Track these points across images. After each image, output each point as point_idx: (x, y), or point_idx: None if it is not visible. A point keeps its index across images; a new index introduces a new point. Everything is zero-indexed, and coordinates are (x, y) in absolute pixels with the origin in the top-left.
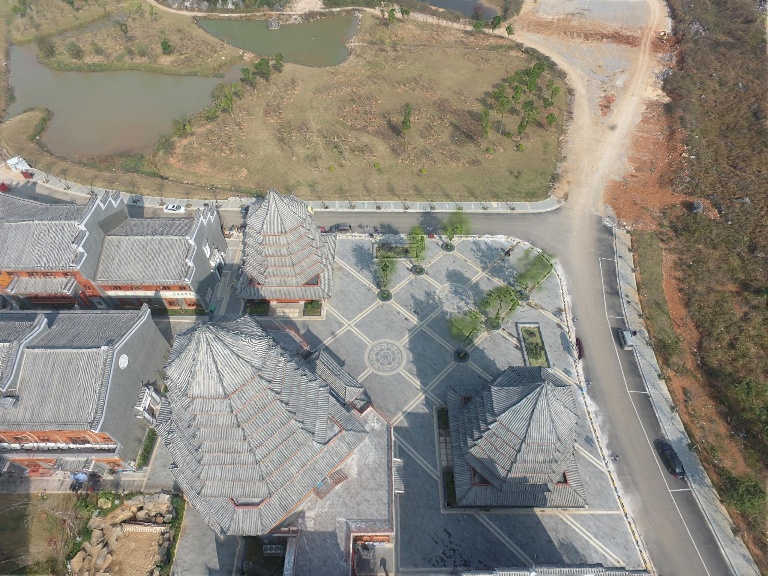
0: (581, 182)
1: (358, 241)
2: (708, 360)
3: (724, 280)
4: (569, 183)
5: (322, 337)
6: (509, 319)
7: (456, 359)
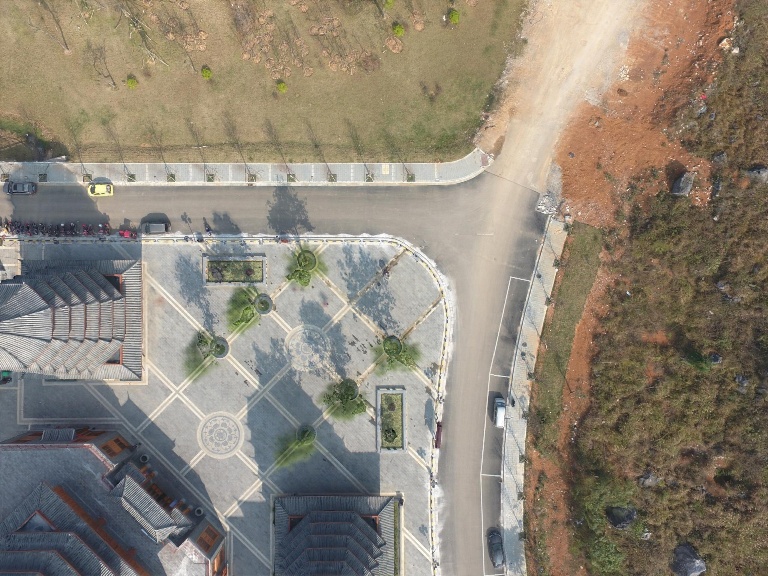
0: (532, 111)
1: (182, 249)
2: (582, 442)
3: (656, 324)
4: (512, 113)
5: (146, 410)
6: (370, 381)
7: (299, 439)
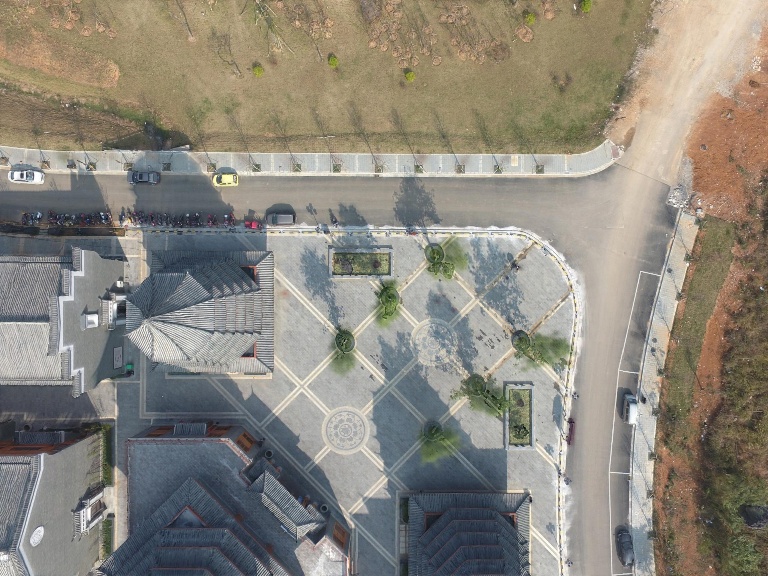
0: (663, 102)
1: (307, 241)
2: (714, 440)
3: None
4: (643, 105)
5: (270, 404)
6: (497, 377)
7: (426, 435)
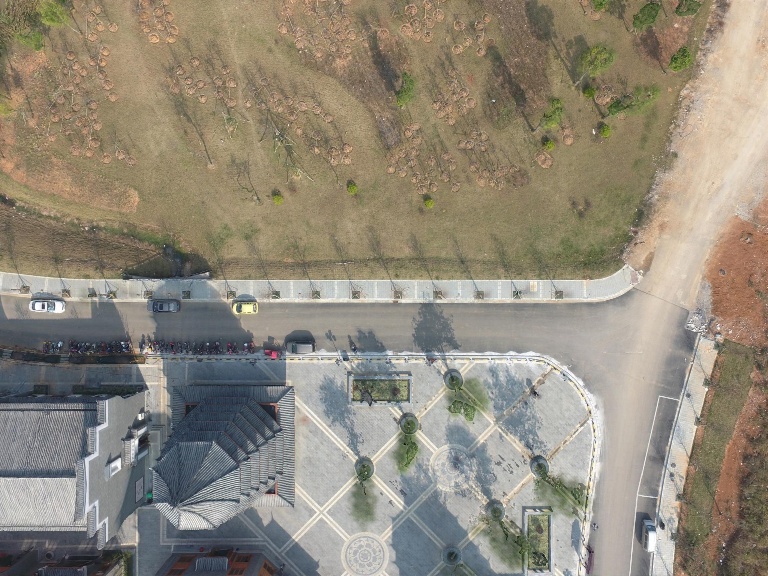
0: (682, 226)
1: (327, 368)
2: (732, 566)
3: None
4: (662, 229)
5: (290, 530)
6: (516, 502)
7: (445, 561)
